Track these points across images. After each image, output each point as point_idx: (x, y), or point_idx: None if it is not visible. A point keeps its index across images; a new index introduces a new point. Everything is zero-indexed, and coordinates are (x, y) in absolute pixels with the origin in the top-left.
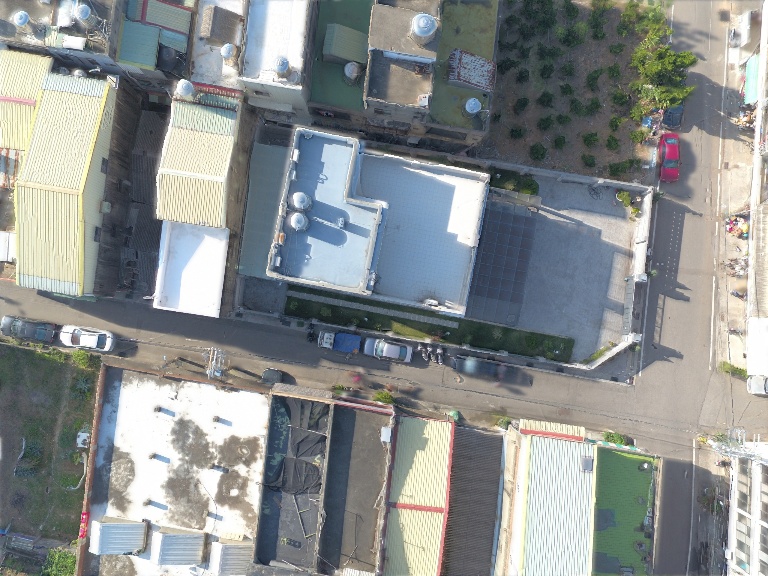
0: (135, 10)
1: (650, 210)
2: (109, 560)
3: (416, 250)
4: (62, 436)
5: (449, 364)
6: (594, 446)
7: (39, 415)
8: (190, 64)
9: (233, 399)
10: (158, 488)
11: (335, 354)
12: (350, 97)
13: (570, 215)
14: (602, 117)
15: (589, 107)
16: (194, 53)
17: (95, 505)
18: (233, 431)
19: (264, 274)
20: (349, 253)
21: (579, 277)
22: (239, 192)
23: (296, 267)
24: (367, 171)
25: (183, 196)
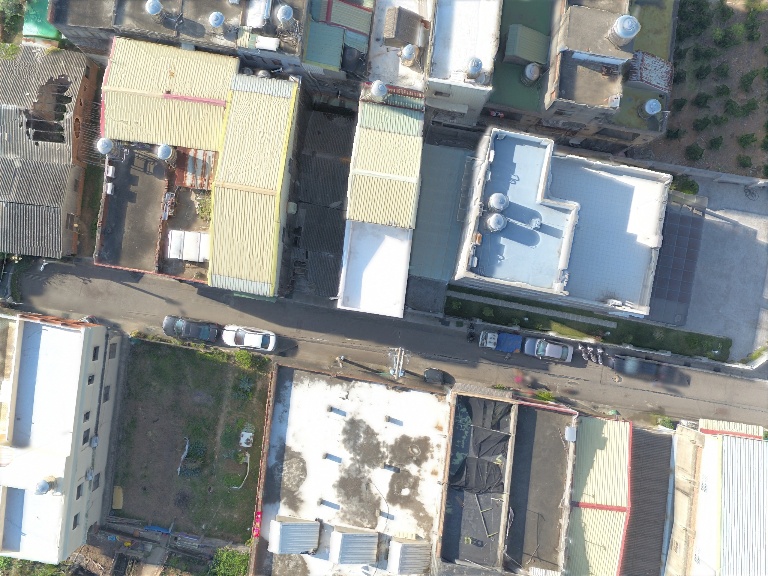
0: (319, 10)
1: None
2: (282, 559)
3: (596, 250)
4: (225, 436)
5: (607, 364)
6: None
7: (202, 415)
8: (367, 64)
9: (404, 399)
10: (330, 487)
11: (494, 354)
12: (527, 98)
13: (726, 215)
14: (756, 118)
15: (745, 108)
16: (371, 53)
17: (267, 504)
18: (404, 431)
19: (433, 274)
20: (542, 254)
21: (735, 277)
22: None
23: (489, 267)
24: None
25: (374, 197)
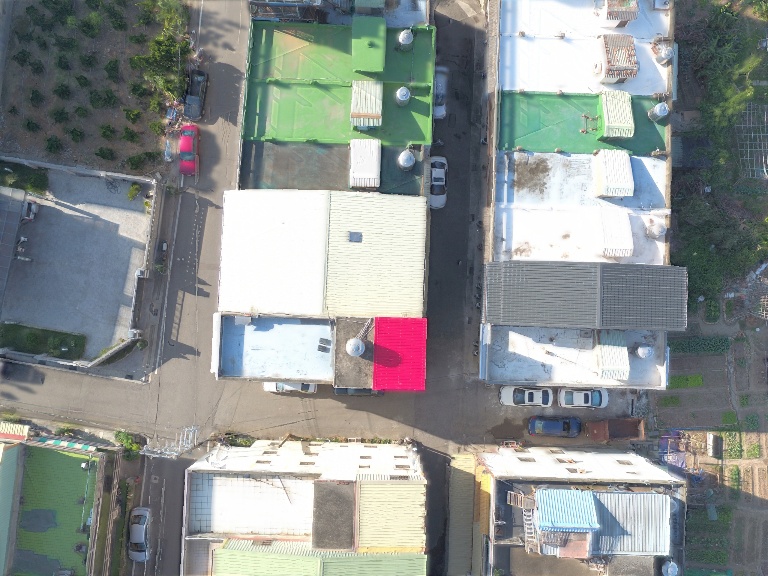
0: None
1: (152, 204)
2: None
3: None
4: None
5: None
6: (0, 445)
7: None
8: None
9: None
10: None
11: None
12: None
13: (86, 209)
14: None
15: (107, 99)
16: None
17: None
18: None
19: None
20: None
21: (94, 273)
22: None
23: None
24: None
25: None
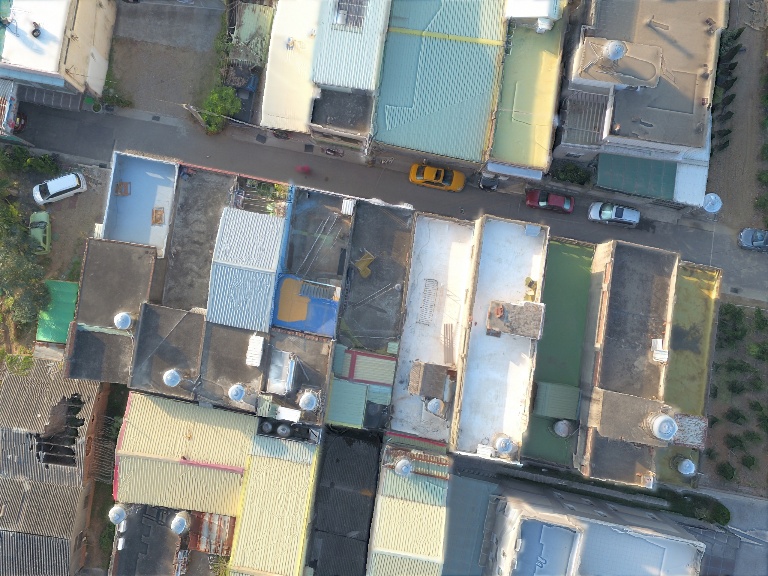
0: (341, 365)
1: None
2: None
3: None
4: None
5: None
6: None
7: None
8: None
9: None
10: None
11: None
12: (554, 447)
13: (757, 536)
14: None
15: None
16: (394, 397)
17: None
18: None
19: None
20: None
21: None
22: None
23: None
24: None
25: (395, 574)
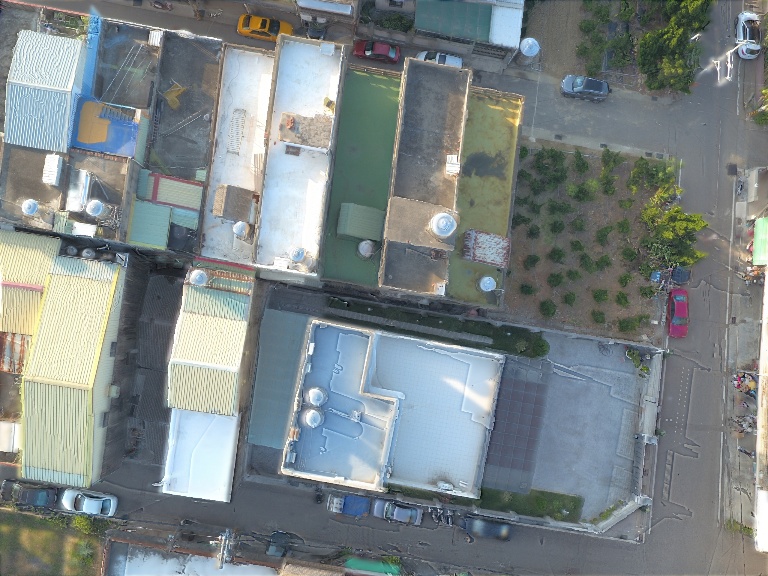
0: (145, 188)
1: (660, 371)
2: None
3: (430, 430)
4: None
5: (459, 524)
6: None
7: None
8: (201, 237)
9: (242, 572)
10: None
11: (344, 515)
12: (363, 271)
13: (580, 372)
14: (611, 271)
15: (599, 263)
16: (205, 226)
17: None
18: None
19: (274, 443)
20: (365, 445)
21: (589, 434)
22: (250, 368)
23: (311, 460)
24: (381, 349)
25: (195, 385)
